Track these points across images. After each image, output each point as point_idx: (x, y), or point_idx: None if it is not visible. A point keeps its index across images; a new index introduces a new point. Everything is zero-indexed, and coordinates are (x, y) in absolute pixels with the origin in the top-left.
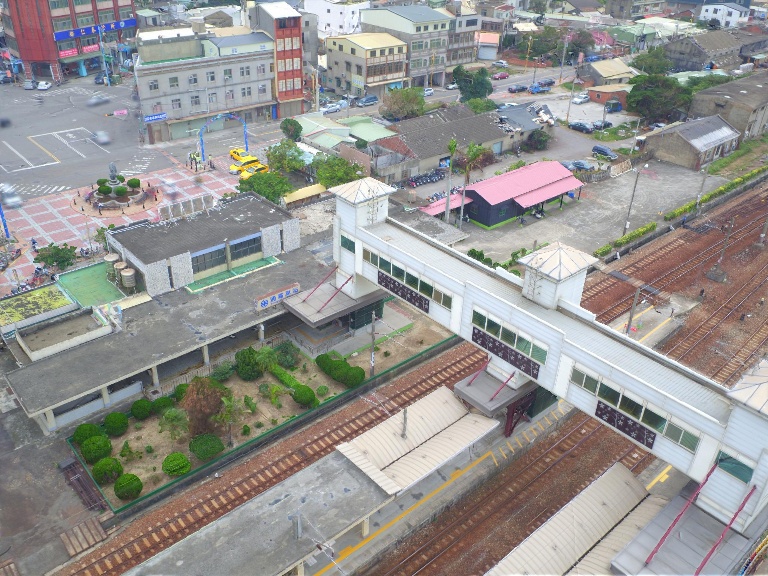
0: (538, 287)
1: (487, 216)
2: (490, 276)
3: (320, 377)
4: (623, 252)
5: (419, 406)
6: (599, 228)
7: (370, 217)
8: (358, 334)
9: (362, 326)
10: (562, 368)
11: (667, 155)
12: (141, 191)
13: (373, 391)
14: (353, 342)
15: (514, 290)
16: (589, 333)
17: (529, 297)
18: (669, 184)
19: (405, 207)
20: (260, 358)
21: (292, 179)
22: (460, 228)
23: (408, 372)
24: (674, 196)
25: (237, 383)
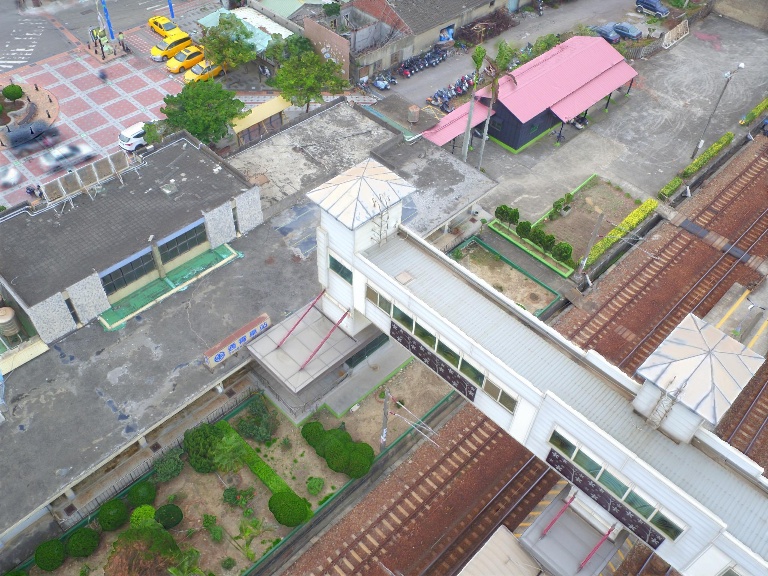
0: (667, 412)
1: (514, 136)
2: (576, 362)
3: (309, 456)
4: (693, 184)
5: (471, 575)
6: (659, 144)
7: (375, 234)
8: (357, 371)
9: (362, 359)
10: (707, 559)
11: (732, 9)
12: (26, 102)
13: (386, 475)
14: (351, 386)
15: (619, 396)
16: (753, 503)
17: (650, 425)
18: (739, 59)
19: (405, 135)
20: (221, 459)
21: (240, 68)
22: (480, 160)
23: (431, 433)
24: (748, 80)
25: (191, 478)
